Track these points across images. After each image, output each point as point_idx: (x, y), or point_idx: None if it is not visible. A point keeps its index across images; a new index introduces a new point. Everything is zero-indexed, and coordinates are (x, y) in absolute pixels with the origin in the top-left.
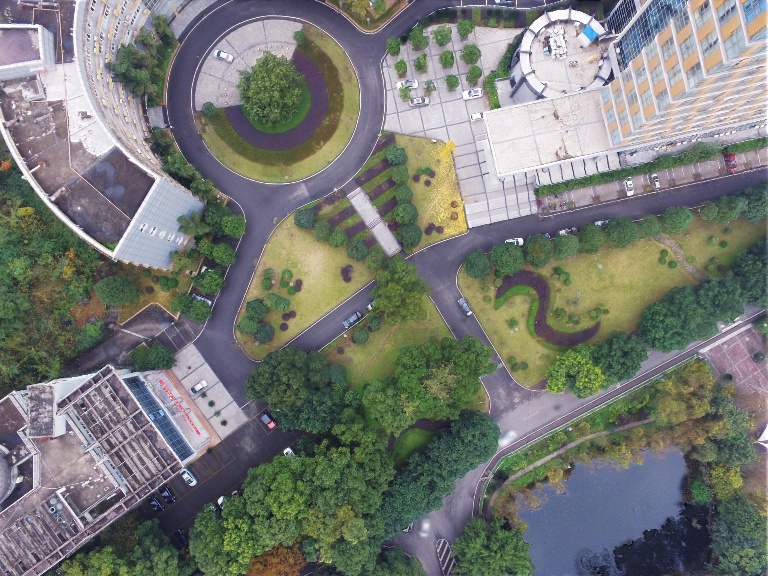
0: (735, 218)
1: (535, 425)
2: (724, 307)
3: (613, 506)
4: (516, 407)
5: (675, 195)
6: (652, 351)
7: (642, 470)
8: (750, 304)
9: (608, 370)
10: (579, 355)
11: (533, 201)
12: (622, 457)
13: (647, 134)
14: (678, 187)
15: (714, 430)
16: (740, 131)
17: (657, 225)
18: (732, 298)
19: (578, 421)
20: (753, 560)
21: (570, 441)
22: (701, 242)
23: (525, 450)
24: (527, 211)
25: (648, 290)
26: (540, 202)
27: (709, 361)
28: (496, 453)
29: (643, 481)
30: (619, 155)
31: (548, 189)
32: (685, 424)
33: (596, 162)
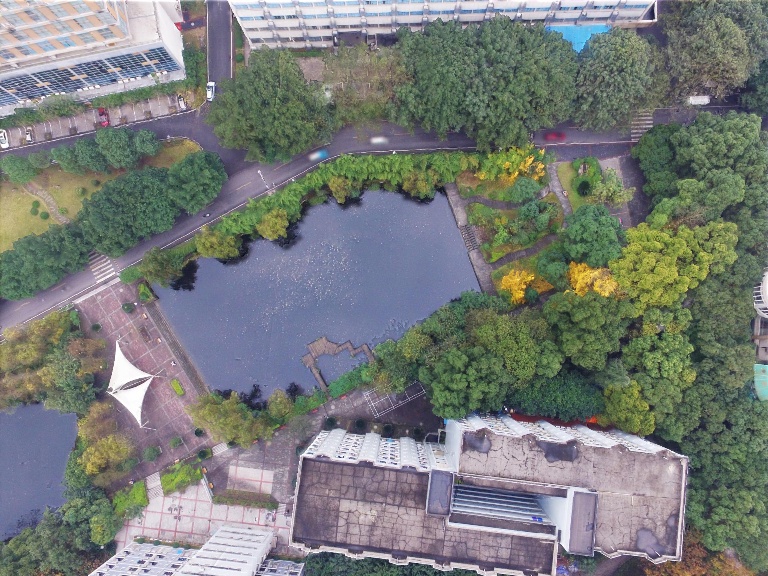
0: (67, 166)
1: None
2: (61, 254)
3: (4, 459)
4: None
5: None
6: (28, 301)
7: (34, 423)
8: (100, 253)
9: None
10: None
11: None
12: None
13: None
14: (54, 140)
15: (41, 376)
16: (106, 86)
17: None
18: (66, 245)
19: None
20: (80, 510)
21: None
22: (74, 194)
23: None
24: None
25: None
26: None
27: (82, 312)
28: None
29: (35, 434)
30: None
31: None
32: None
33: None
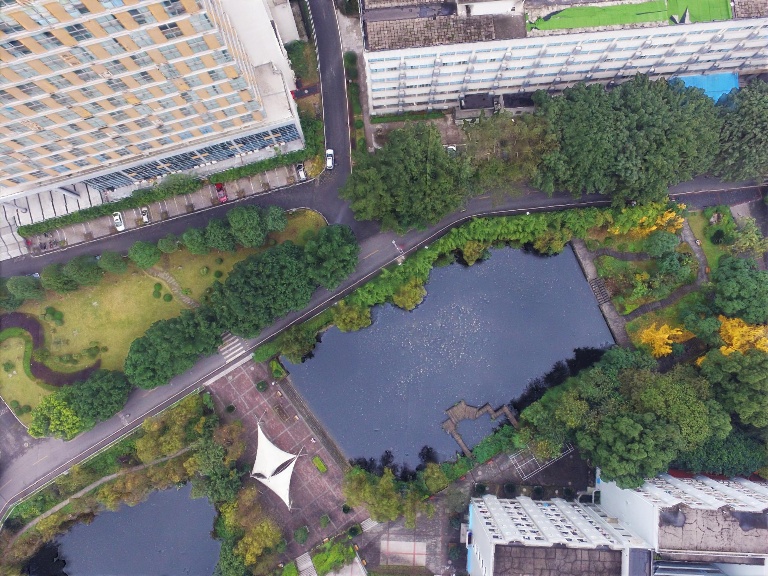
0: (196, 249)
1: (45, 469)
2: (196, 339)
3: (140, 549)
4: (26, 452)
5: (169, 227)
6: None
7: (168, 509)
8: (233, 334)
9: (79, 411)
10: (53, 397)
11: (21, 242)
12: (107, 500)
13: (15, 176)
14: (171, 219)
15: (187, 467)
16: (222, 161)
17: (103, 262)
18: (201, 330)
19: (86, 463)
20: None
21: (86, 484)
22: (196, 273)
23: (35, 496)
24: (16, 252)
25: (147, 325)
26: (29, 242)
27: (214, 394)
28: (7, 501)
29: (170, 521)
30: (99, 191)
31: (26, 229)
32: (168, 462)
33: (77, 199)
